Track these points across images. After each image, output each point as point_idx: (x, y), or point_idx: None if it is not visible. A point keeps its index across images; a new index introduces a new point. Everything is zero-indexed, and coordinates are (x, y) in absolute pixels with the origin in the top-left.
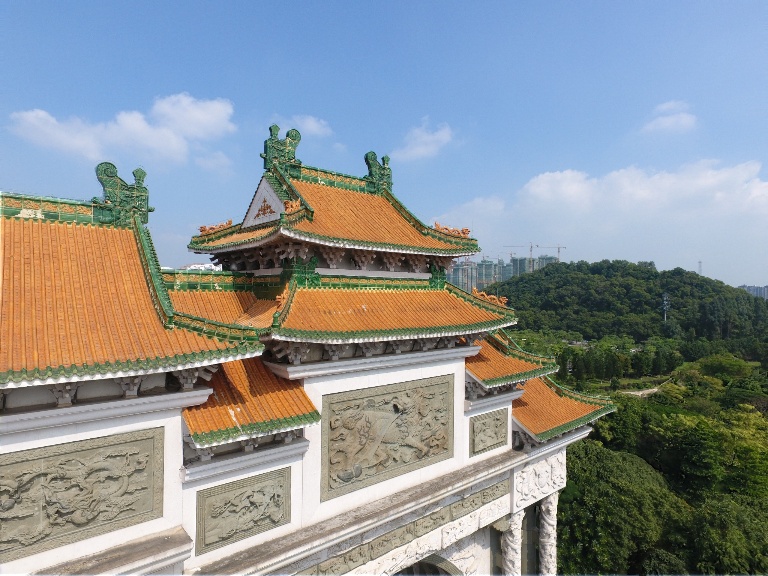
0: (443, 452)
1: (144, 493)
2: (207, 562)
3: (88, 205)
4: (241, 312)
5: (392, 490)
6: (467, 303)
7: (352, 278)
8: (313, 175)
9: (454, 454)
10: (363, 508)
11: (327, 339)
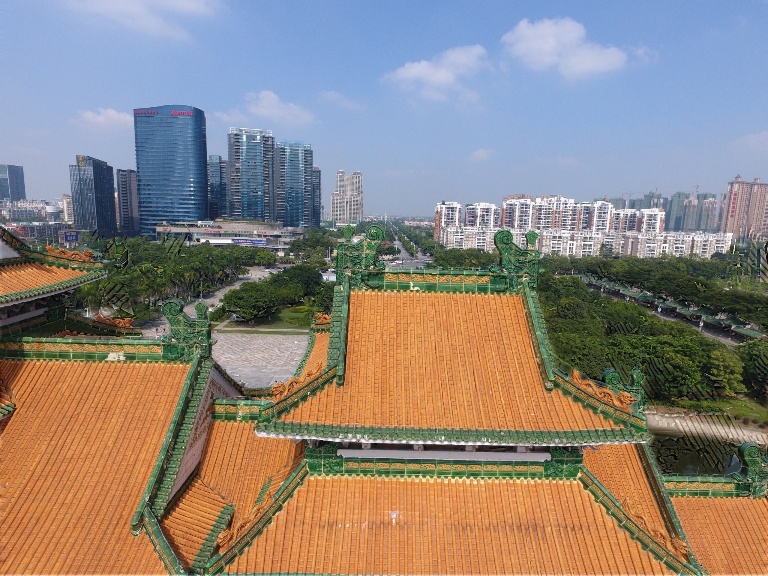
0: None
1: None
2: None
3: (158, 344)
4: (291, 458)
5: None
6: (610, 519)
7: (394, 462)
8: (403, 280)
9: None
10: None
11: None
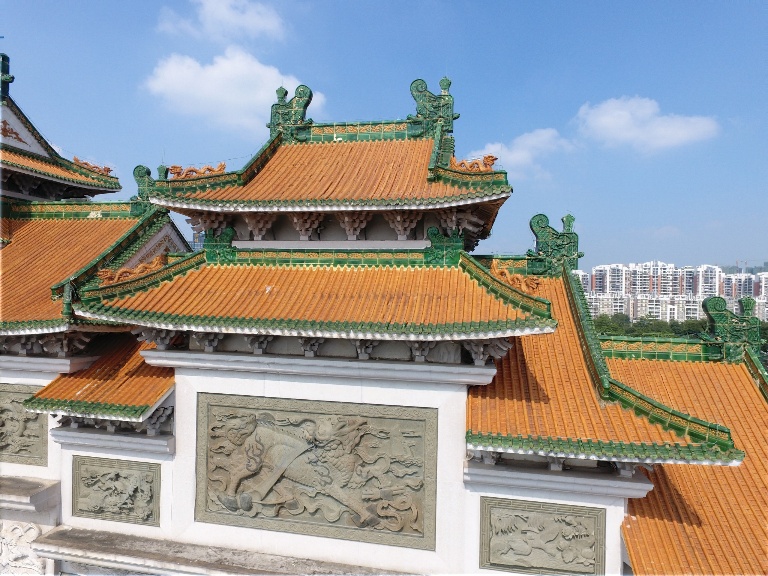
0: (412, 534)
1: (37, 440)
2: (80, 526)
3: (128, 203)
4: None
5: (303, 552)
6: (480, 289)
7: (281, 251)
8: (328, 133)
9: (437, 547)
10: (247, 554)
11: (150, 322)
